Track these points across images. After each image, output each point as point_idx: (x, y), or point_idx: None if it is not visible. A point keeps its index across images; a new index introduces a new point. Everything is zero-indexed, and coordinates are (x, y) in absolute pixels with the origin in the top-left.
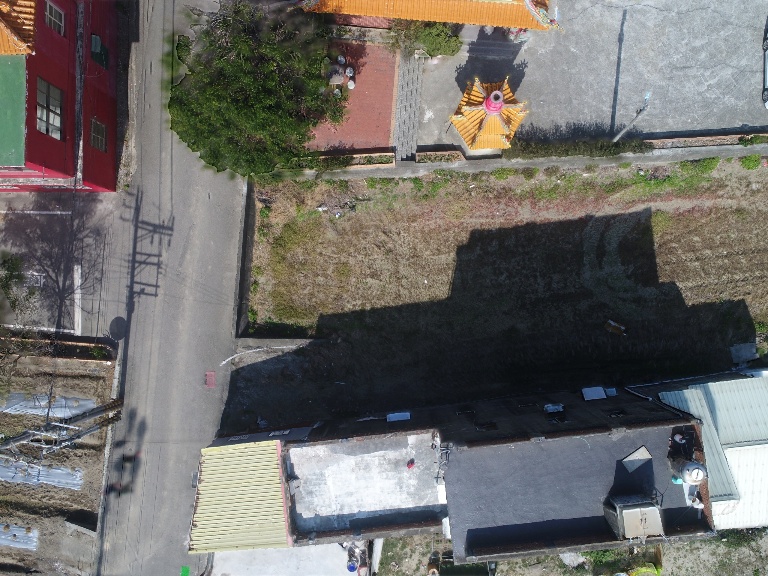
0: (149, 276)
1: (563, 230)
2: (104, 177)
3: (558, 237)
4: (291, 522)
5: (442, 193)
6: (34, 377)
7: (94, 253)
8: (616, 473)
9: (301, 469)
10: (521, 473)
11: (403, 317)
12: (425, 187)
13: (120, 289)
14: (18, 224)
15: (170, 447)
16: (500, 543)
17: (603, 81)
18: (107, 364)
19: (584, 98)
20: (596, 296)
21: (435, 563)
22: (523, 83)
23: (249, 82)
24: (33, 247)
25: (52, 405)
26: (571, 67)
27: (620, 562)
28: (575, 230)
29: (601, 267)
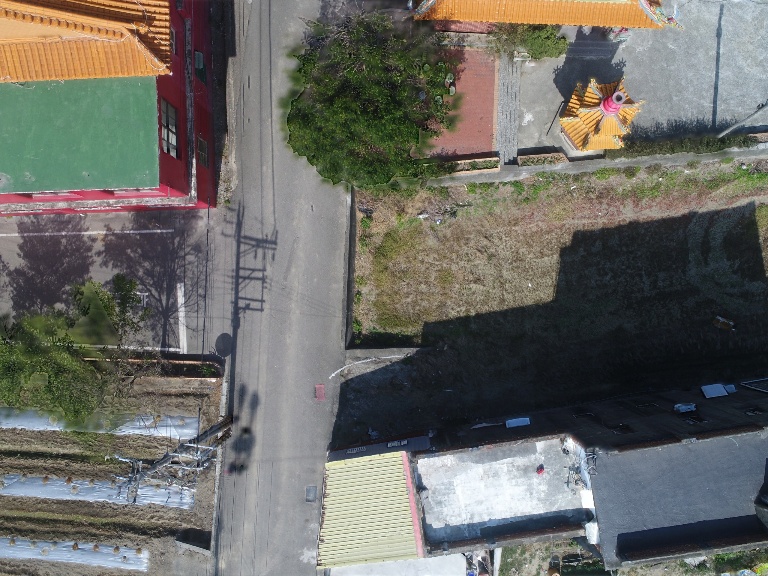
0: (254, 291)
1: (667, 228)
2: (207, 194)
3: (662, 235)
4: (423, 533)
5: (543, 195)
6: (138, 397)
7: (197, 270)
8: (766, 471)
9: (429, 479)
10: (669, 475)
11: (508, 322)
12: (526, 190)
13: (225, 305)
14: (118, 244)
15: (282, 462)
16: (651, 546)
17: (703, 77)
18: (212, 381)
19: (684, 94)
20: (703, 292)
21: (555, 567)
22: (622, 82)
23: (375, 93)
24: (134, 267)
25: (157, 424)
26: (670, 64)
27: (742, 559)
28: (679, 227)
29: (707, 263)
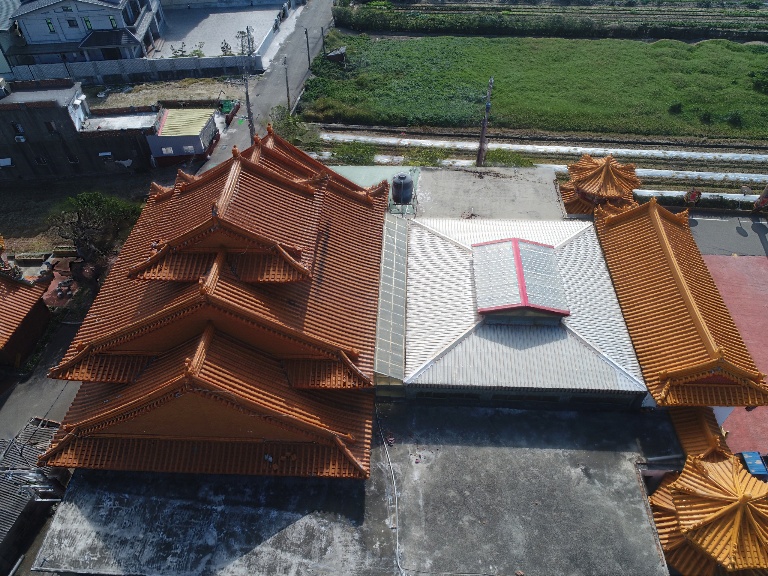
0: None
1: None
2: None
3: None
4: None
5: None
6: None
7: None
8: None
9: None
10: None
11: None
12: None
13: None
14: None
15: None
16: (59, 86)
17: None
18: None
19: None
20: None
21: None
22: None
23: None
24: None
25: None
26: None
27: None
28: None
29: None
